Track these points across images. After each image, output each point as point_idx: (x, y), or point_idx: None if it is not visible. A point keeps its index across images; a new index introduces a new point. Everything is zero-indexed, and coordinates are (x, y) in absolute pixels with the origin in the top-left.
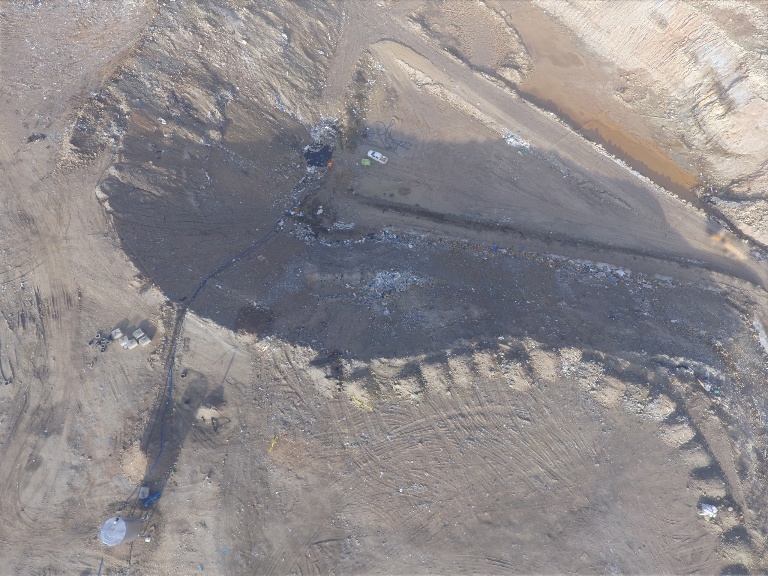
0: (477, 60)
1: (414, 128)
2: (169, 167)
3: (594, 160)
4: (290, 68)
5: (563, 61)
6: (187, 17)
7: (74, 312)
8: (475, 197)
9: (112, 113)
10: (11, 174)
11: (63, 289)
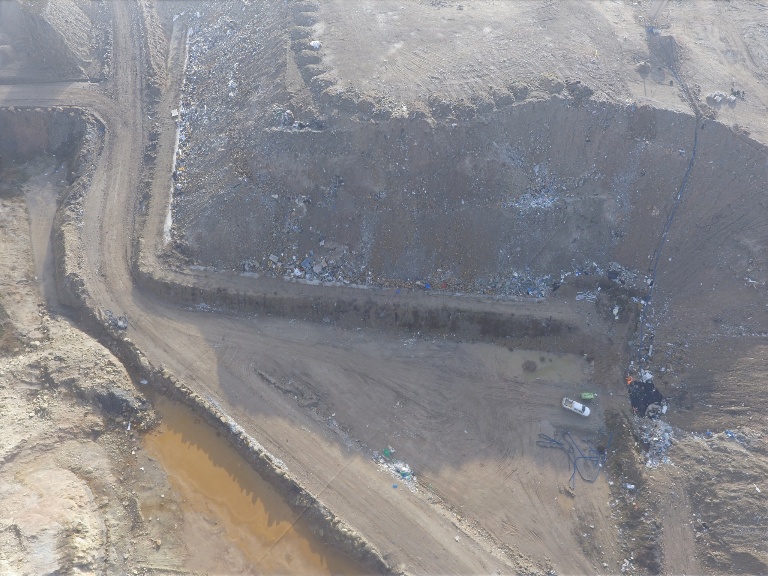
0: None
1: (540, 477)
2: None
3: (292, 444)
4: (760, 504)
5: None
6: None
7: None
8: (446, 370)
9: None
10: None
11: None
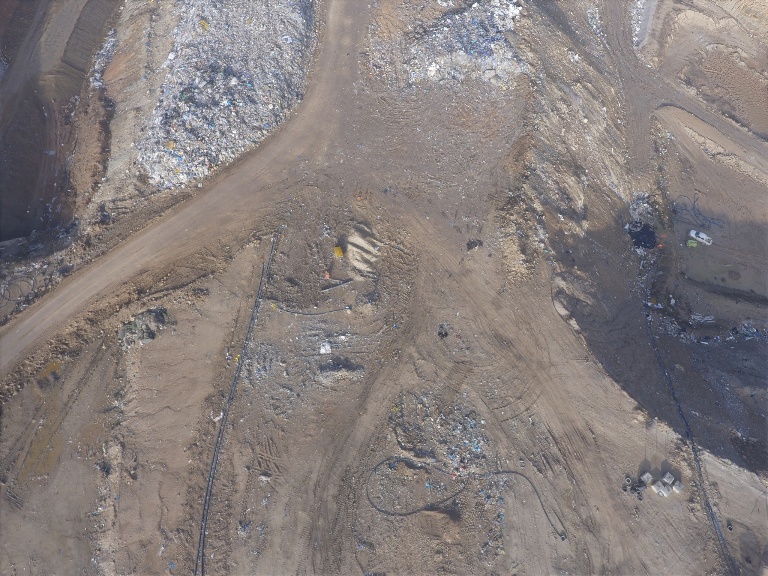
0: (756, 127)
1: (720, 203)
2: (584, 270)
3: None
4: (612, 143)
5: None
6: (550, 99)
7: (594, 452)
8: None
9: (533, 214)
10: (466, 287)
11: (573, 425)
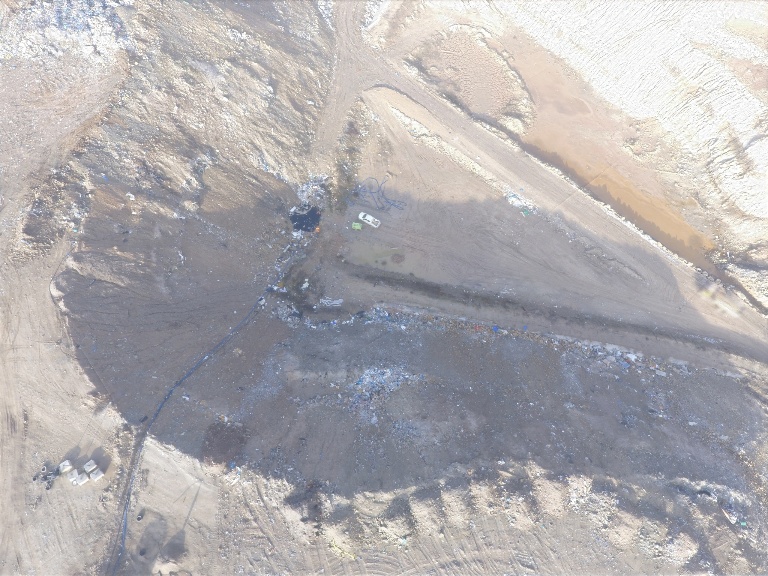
0: (477, 107)
1: (409, 185)
2: (136, 251)
3: (602, 223)
4: (276, 124)
5: (569, 108)
6: (162, 76)
7: (18, 439)
8: (474, 265)
9: (73, 193)
10: None
11: (7, 411)
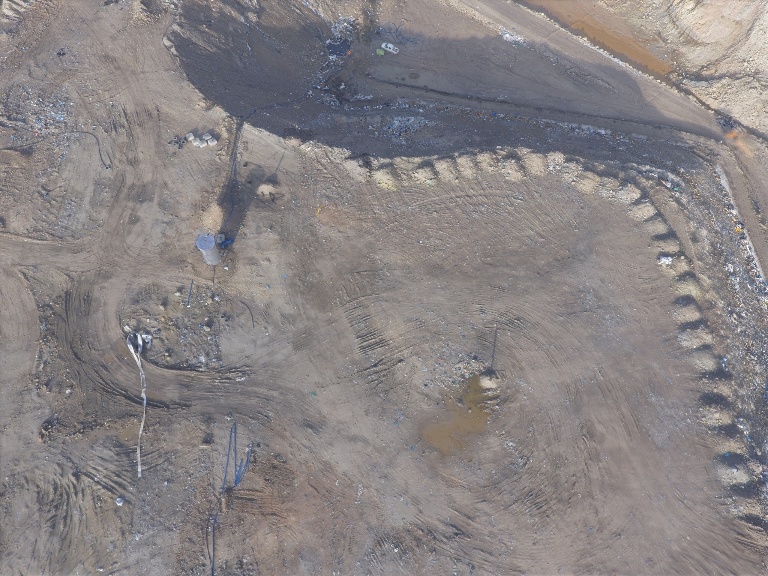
0: None
1: (421, 28)
2: (219, 32)
3: (580, 50)
4: None
5: None
6: None
7: (155, 122)
8: (476, 80)
9: None
10: (93, 28)
11: (144, 107)
